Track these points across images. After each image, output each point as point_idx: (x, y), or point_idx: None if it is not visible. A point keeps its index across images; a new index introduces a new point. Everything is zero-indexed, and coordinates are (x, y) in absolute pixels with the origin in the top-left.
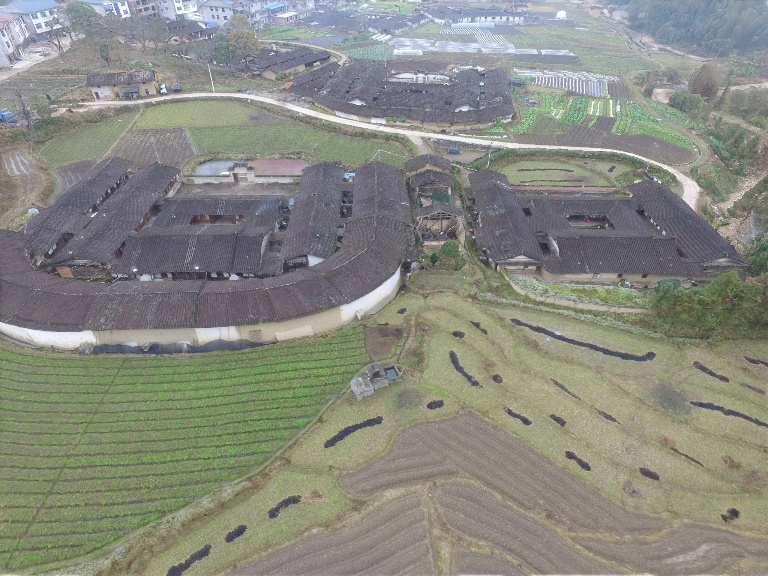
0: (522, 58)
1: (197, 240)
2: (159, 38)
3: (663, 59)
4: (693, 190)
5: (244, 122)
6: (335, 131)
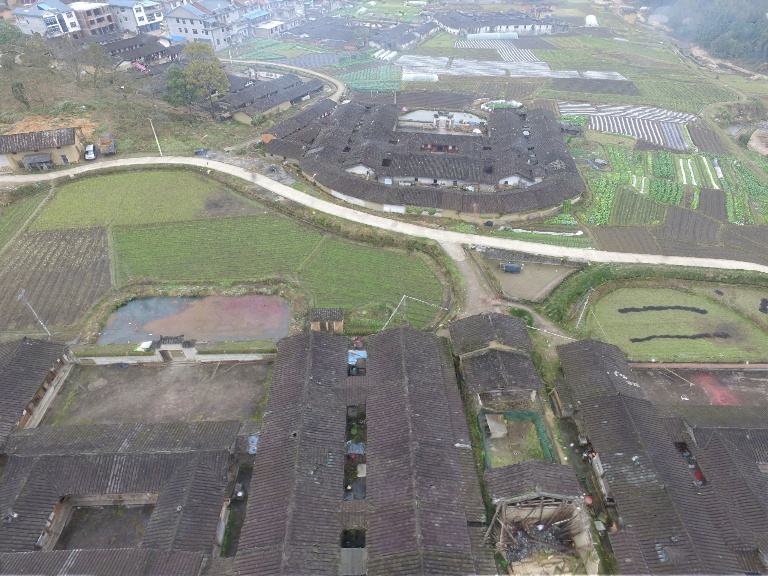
0: (563, 85)
1: None
2: (105, 64)
3: (733, 82)
4: None
5: (197, 213)
6: (331, 231)
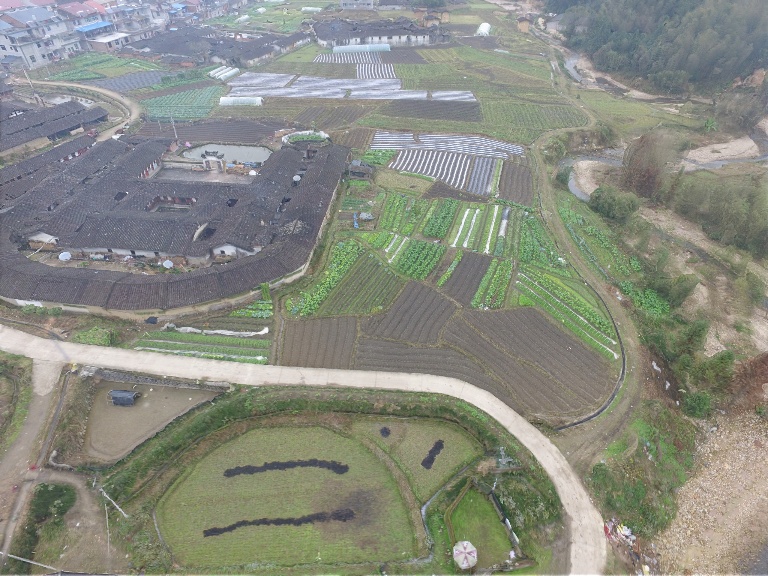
0: (399, 108)
1: None
2: None
3: (597, 101)
4: (591, 560)
5: None
6: None
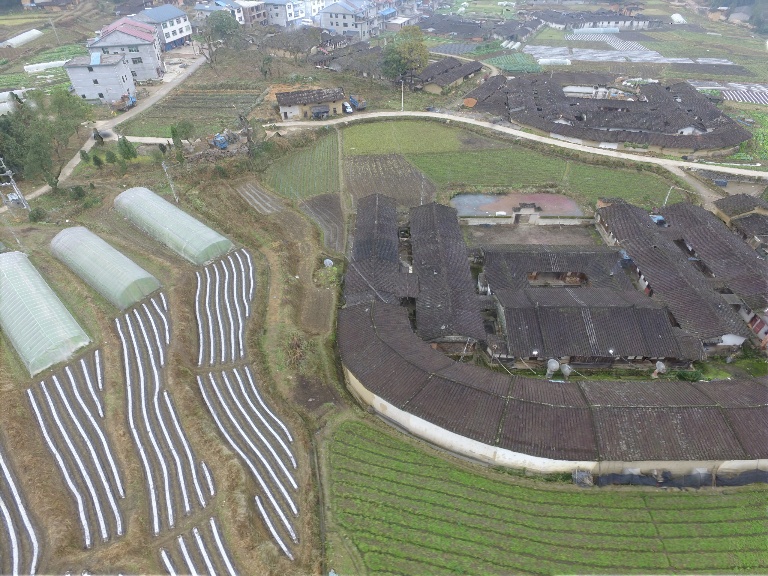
0: (683, 68)
1: (591, 313)
2: None
3: None
4: None
5: (460, 147)
6: (571, 158)
